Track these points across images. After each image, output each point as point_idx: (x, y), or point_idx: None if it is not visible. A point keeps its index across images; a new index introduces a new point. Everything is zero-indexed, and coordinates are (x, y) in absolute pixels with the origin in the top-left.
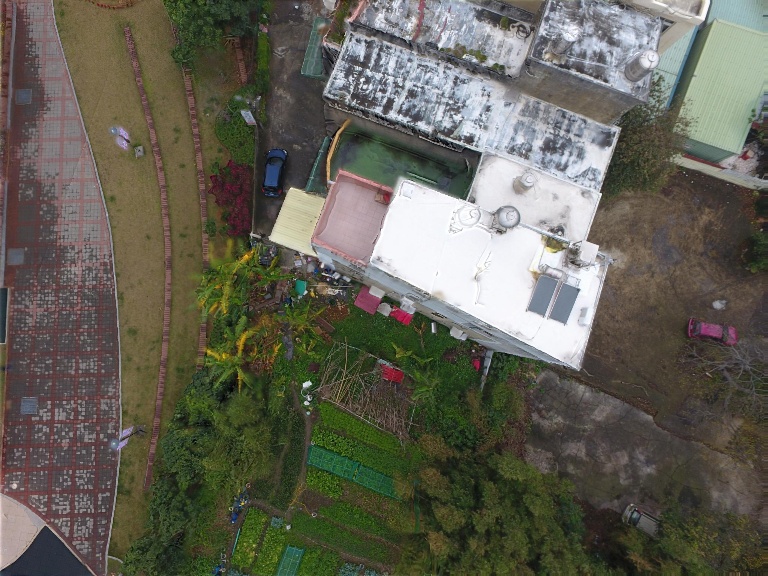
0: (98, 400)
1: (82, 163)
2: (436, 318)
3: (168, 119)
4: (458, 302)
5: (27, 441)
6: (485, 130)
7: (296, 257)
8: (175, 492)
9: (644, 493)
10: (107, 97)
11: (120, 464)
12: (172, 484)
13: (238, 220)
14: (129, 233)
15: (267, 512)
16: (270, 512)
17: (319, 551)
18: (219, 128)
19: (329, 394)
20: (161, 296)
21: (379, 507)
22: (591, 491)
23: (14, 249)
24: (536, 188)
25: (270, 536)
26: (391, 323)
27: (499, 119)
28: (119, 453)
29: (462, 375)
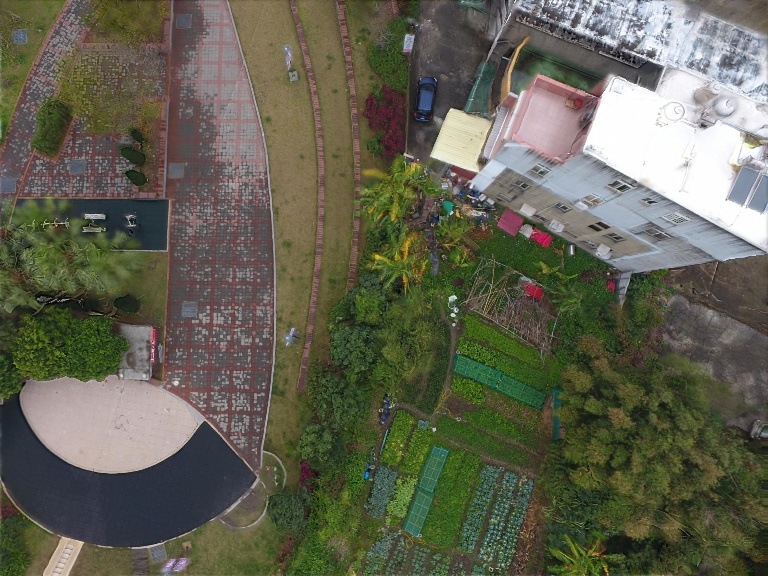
0: (254, 307)
1: (239, 85)
2: (584, 236)
3: (322, 46)
4: (662, 190)
5: (188, 342)
6: (666, 45)
7: (443, 179)
8: (346, 383)
9: (767, 412)
10: (263, 24)
11: (274, 367)
12: (340, 377)
13: (392, 141)
14: (284, 152)
15: (414, 415)
16: (416, 416)
17: (462, 453)
18: (374, 55)
19: (477, 306)
20: (313, 212)
21: (518, 415)
22: (718, 408)
23: (175, 164)
24: (715, 99)
25: (417, 437)
26: (532, 244)
27: (679, 36)
28: (273, 357)
29: (600, 294)
